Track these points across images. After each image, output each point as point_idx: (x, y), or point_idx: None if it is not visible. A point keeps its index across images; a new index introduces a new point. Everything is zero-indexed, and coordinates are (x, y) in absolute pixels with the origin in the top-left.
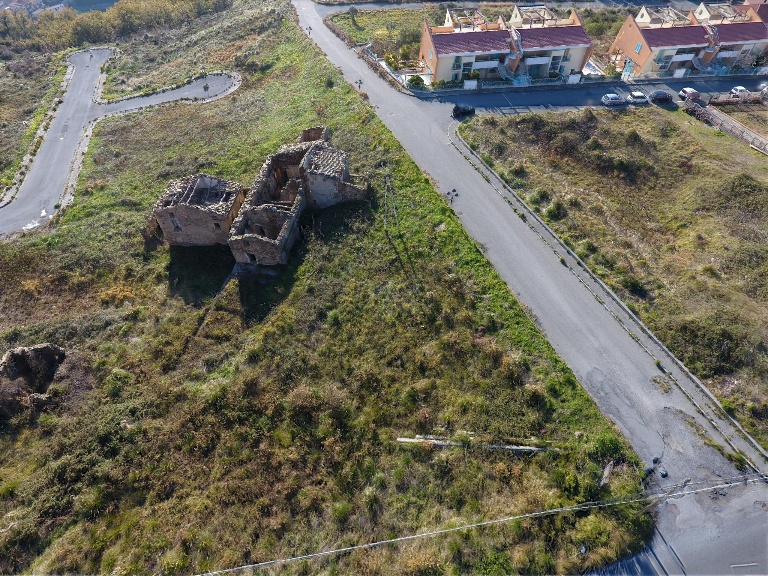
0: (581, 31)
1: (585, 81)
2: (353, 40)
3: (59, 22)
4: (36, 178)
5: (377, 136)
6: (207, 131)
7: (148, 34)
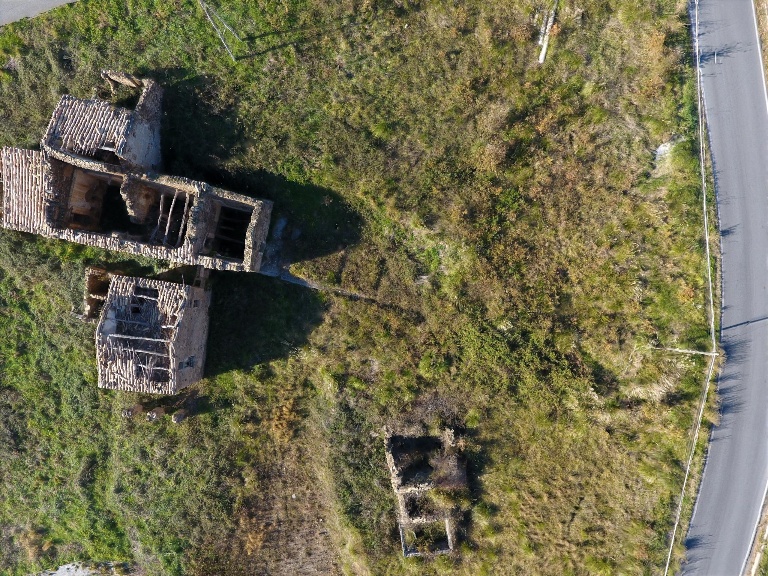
0: None
1: None
2: None
3: None
4: None
5: None
6: None
7: None
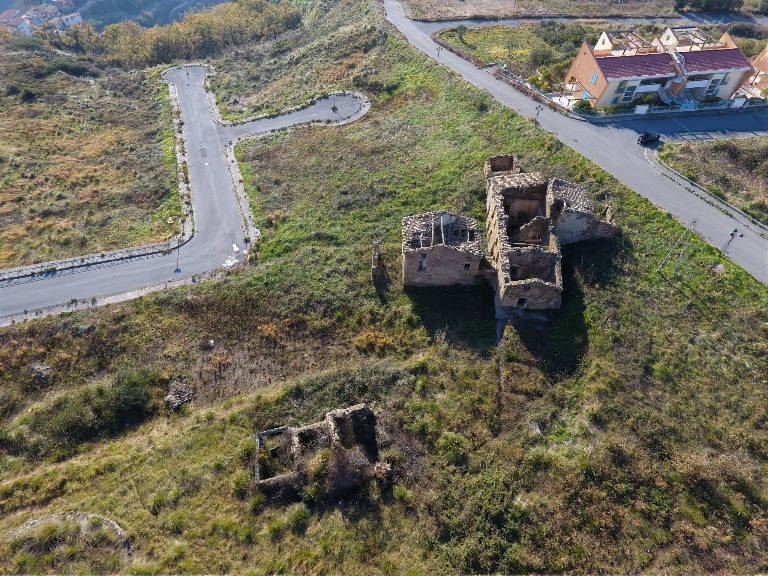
0: (739, 54)
1: (748, 105)
2: (481, 60)
3: (131, 37)
4: (205, 208)
5: (579, 166)
6: (363, 156)
7: (238, 50)
